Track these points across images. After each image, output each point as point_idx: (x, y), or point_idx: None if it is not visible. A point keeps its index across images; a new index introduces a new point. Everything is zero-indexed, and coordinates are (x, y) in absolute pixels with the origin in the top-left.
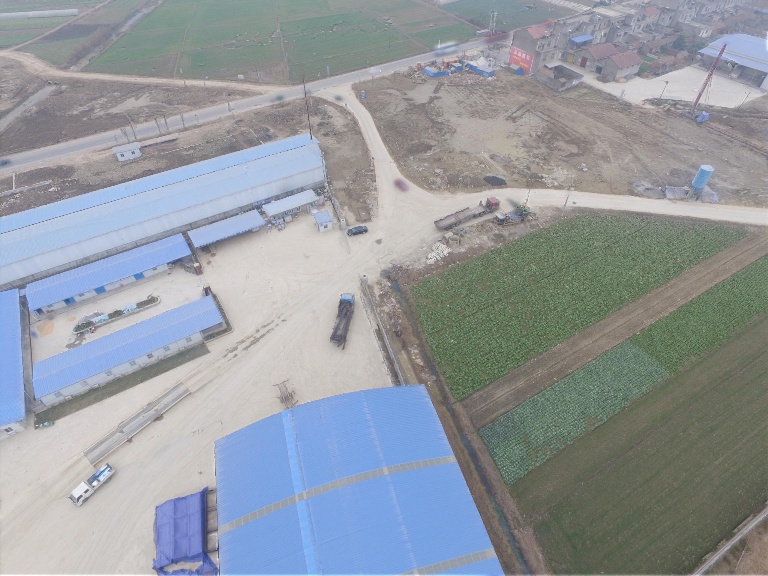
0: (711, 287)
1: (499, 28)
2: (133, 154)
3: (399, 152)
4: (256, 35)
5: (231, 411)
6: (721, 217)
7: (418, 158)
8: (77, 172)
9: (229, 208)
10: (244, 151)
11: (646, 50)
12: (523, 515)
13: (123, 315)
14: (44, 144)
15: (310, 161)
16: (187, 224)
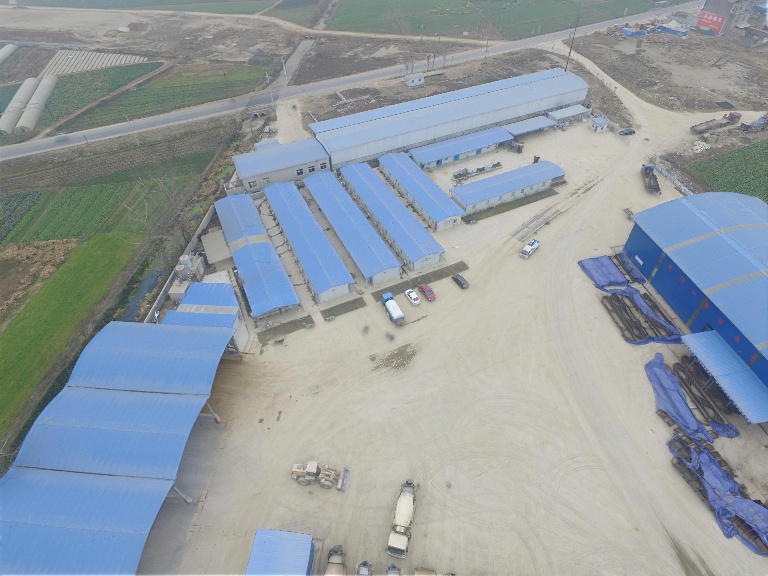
0: None
1: (672, 1)
2: (419, 81)
3: (631, 86)
4: (452, 6)
5: (596, 223)
6: None
7: (649, 90)
8: (385, 91)
9: (522, 114)
10: (516, 78)
11: None
12: None
13: (482, 172)
14: (338, 76)
15: (576, 84)
16: (495, 123)
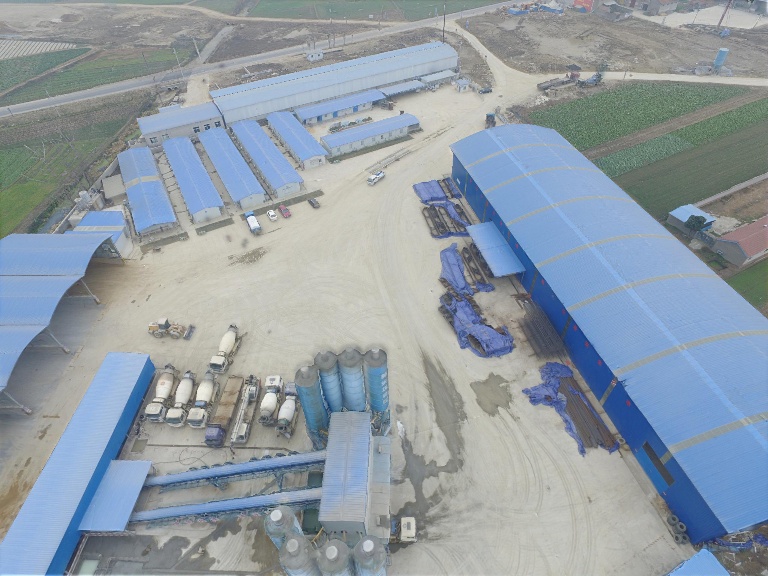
0: (723, 113)
1: None
2: (318, 56)
3: (502, 55)
4: None
5: (437, 158)
6: (733, 83)
7: (516, 58)
8: (286, 65)
9: (399, 79)
10: (399, 50)
11: None
12: None
13: (355, 125)
14: None
15: (448, 53)
16: (374, 87)
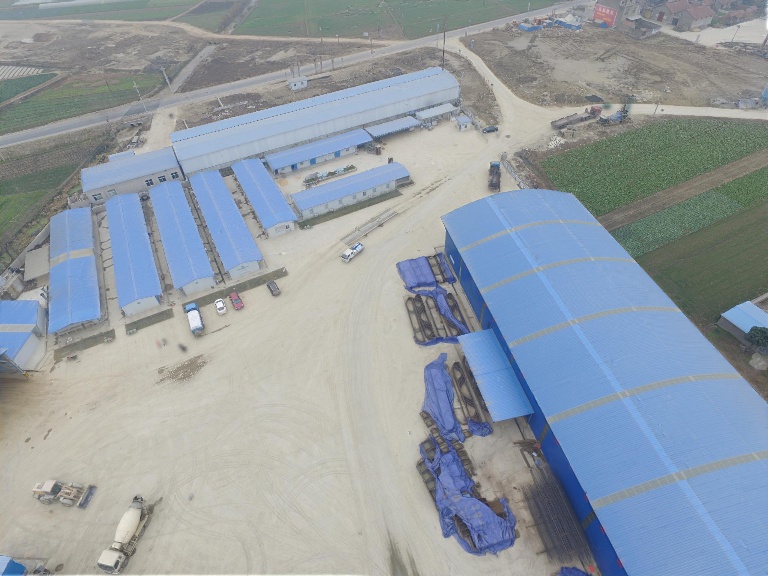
0: None
1: None
2: (302, 85)
3: (510, 82)
4: (365, 6)
5: (428, 223)
6: None
7: (527, 86)
8: (265, 96)
9: (390, 115)
10: (392, 78)
11: (717, 6)
12: None
13: (334, 175)
14: (228, 81)
15: (447, 83)
16: (361, 125)
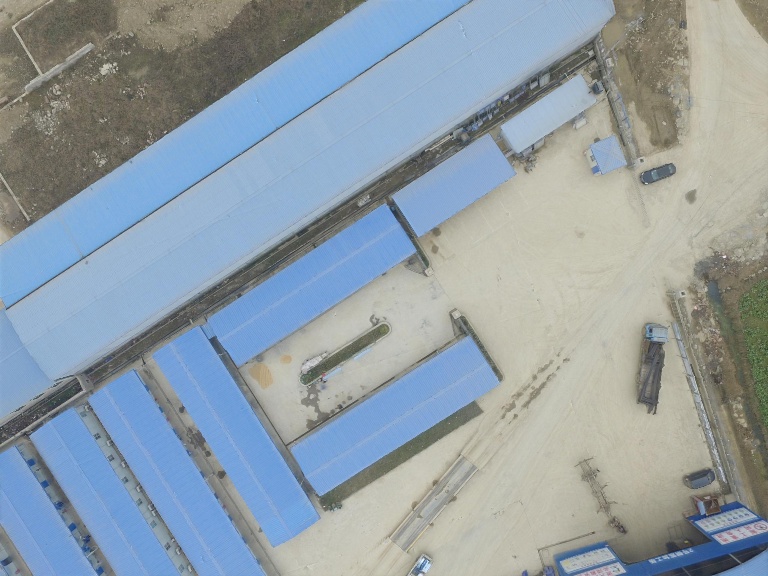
0: None
1: None
2: None
3: None
4: None
5: (529, 490)
6: None
7: None
8: (125, 17)
9: (443, 131)
10: None
11: None
12: None
13: (353, 356)
14: None
15: (586, 5)
16: (382, 172)
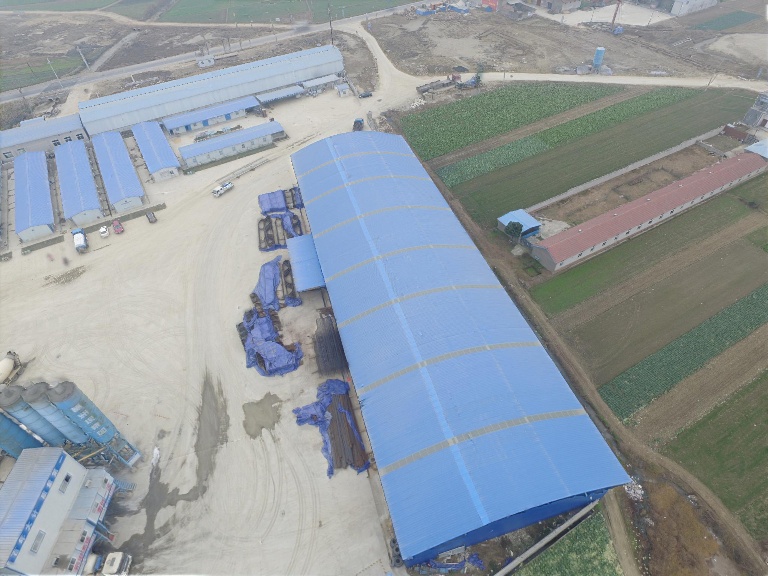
0: (591, 113)
1: None
2: (209, 62)
3: (395, 57)
4: None
5: None
6: (611, 82)
7: (408, 60)
8: (174, 72)
9: (280, 85)
10: (287, 55)
11: None
12: (454, 196)
13: (222, 133)
14: (144, 62)
15: (333, 57)
16: (254, 93)
